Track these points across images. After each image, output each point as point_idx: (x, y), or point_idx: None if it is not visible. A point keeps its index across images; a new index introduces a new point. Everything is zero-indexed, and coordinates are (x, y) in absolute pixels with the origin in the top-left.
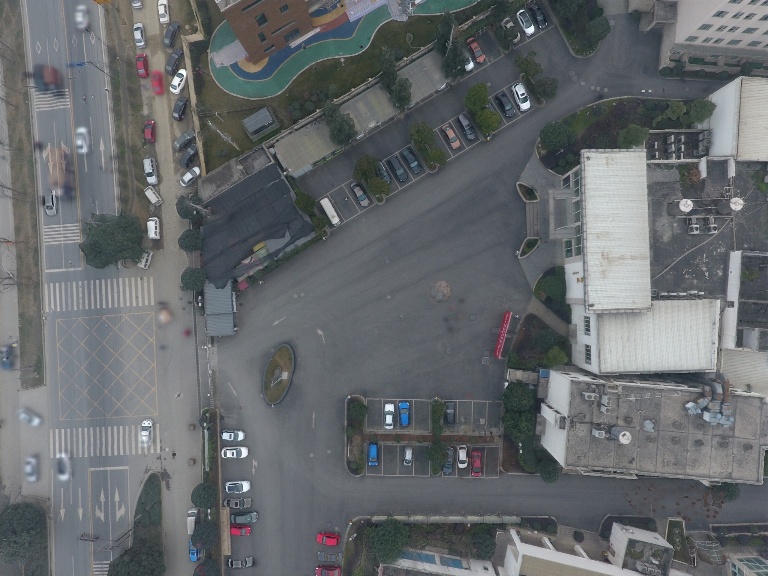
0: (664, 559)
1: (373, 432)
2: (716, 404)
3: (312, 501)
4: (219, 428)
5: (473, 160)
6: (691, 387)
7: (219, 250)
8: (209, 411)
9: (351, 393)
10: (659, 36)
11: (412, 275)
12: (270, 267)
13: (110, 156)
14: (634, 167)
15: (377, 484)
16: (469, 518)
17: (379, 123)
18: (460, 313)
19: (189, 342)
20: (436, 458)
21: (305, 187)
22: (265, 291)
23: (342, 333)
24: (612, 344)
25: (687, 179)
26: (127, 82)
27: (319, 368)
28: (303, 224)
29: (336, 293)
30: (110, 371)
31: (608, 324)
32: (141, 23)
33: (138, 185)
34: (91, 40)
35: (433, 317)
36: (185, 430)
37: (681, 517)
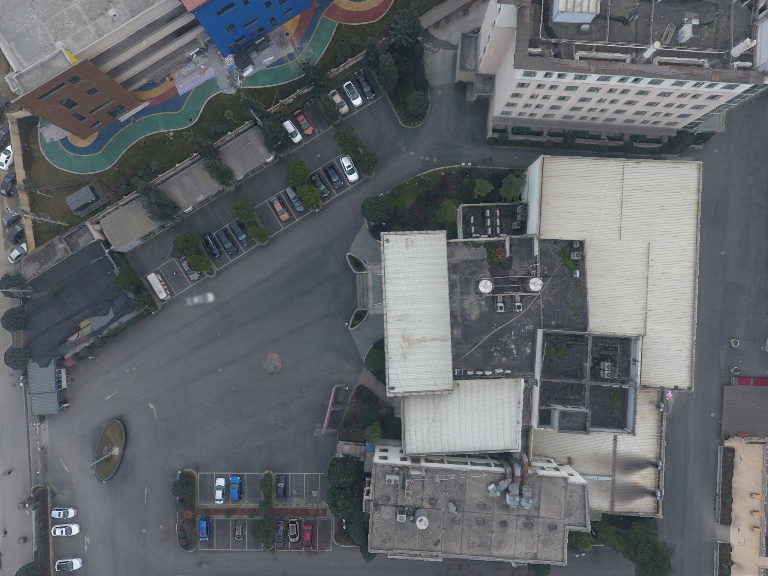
0: None
1: (205, 507)
2: (515, 486)
3: None
4: (50, 505)
5: (303, 231)
6: (499, 466)
7: (44, 328)
8: (37, 490)
9: (183, 467)
10: (486, 105)
11: (243, 348)
12: (96, 344)
13: None
14: (434, 249)
15: (210, 559)
16: None
17: (203, 198)
18: (292, 385)
19: (20, 419)
20: (258, 536)
21: (136, 261)
22: (97, 366)
23: (174, 407)
24: (418, 425)
25: (494, 257)
26: None
27: (151, 443)
28: (126, 301)
29: (168, 367)
30: None
31: (414, 405)
32: None
33: None
34: None
35: (265, 390)
36: (16, 508)
37: None
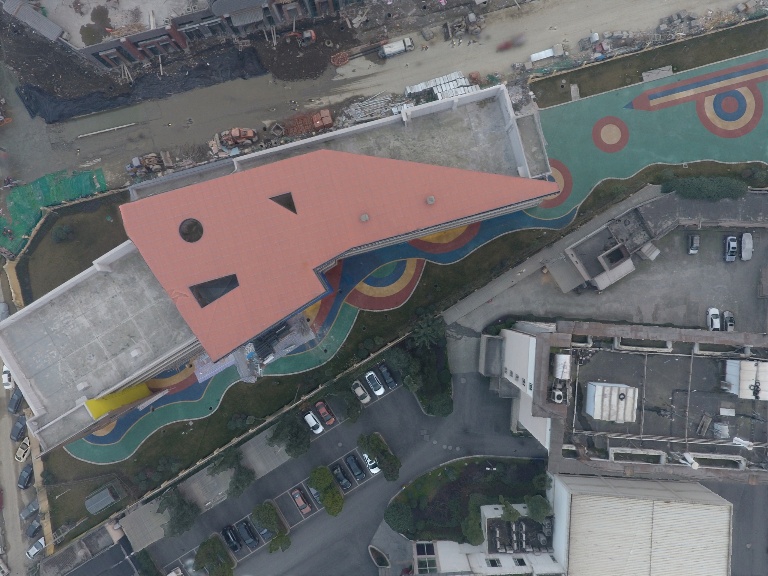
0: None
1: None
2: None
3: None
4: None
5: (325, 522)
6: None
7: None
8: None
9: None
10: None
11: None
12: None
13: None
14: None
15: None
16: None
17: (224, 499)
18: None
19: None
20: None
21: (155, 552)
22: None
23: None
24: None
25: None
26: None
27: None
28: None
29: None
30: None
31: None
32: None
33: None
34: None
35: None
36: None
37: None
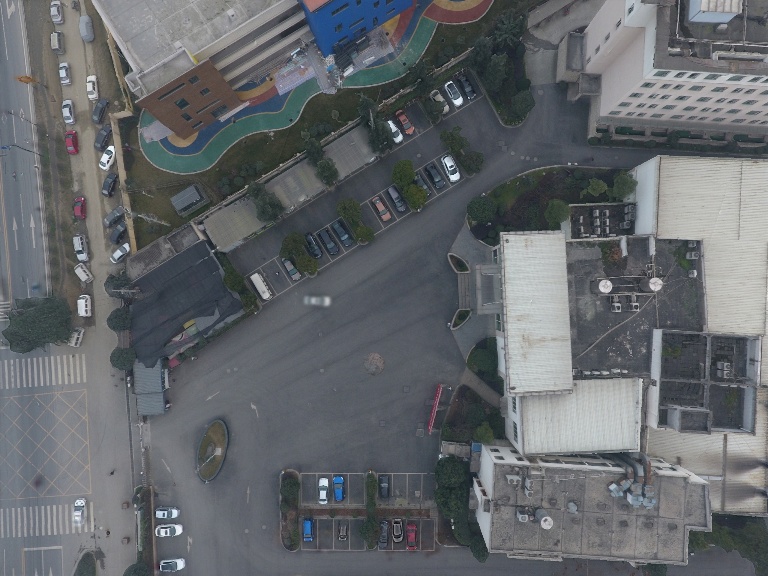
0: None
1: (308, 507)
2: (638, 486)
3: None
4: (153, 506)
5: (404, 231)
6: (616, 466)
7: (149, 328)
8: (141, 490)
9: (285, 468)
10: (587, 105)
11: (345, 348)
12: (201, 344)
13: (40, 234)
14: (553, 248)
15: (313, 559)
16: None
17: (307, 198)
18: (393, 385)
19: (122, 419)
20: (367, 536)
21: (237, 261)
22: (198, 366)
23: (276, 407)
24: (536, 425)
25: (609, 257)
26: (57, 159)
27: (253, 443)
28: (232, 301)
29: (269, 367)
30: (43, 450)
31: (532, 405)
32: (70, 100)
33: (69, 262)
34: (20, 117)
35: (367, 390)
36: (119, 508)
37: None
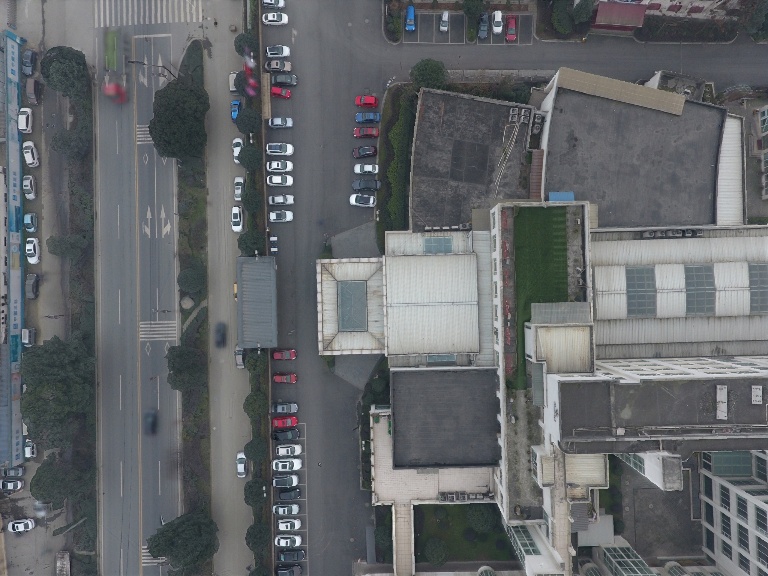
0: (696, 95)
1: None
2: None
3: (350, 68)
4: None
5: None
6: None
7: None
8: None
9: None
10: None
11: None
12: None
13: None
14: None
15: (414, 52)
16: (504, 70)
17: None
18: None
19: None
20: None
21: None
22: None
23: None
24: None
25: None
26: None
27: None
28: None
29: None
30: None
31: None
32: None
33: None
34: None
35: None
36: None
37: (710, 81)
